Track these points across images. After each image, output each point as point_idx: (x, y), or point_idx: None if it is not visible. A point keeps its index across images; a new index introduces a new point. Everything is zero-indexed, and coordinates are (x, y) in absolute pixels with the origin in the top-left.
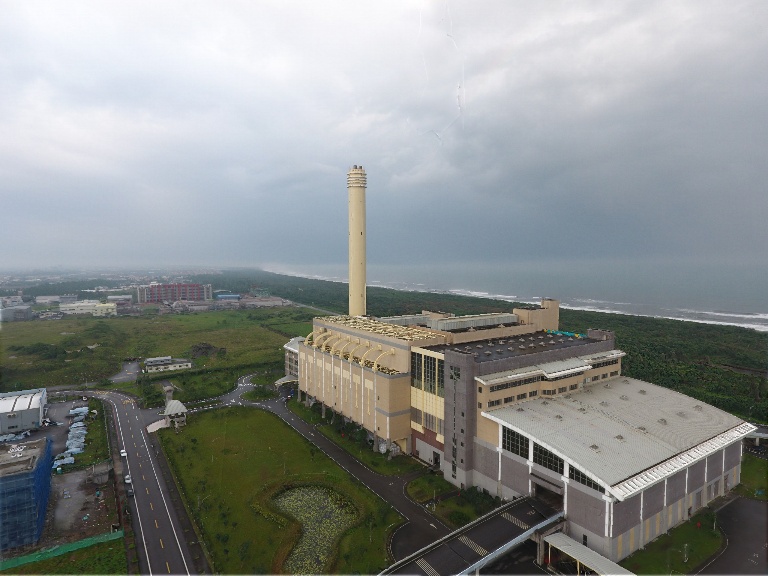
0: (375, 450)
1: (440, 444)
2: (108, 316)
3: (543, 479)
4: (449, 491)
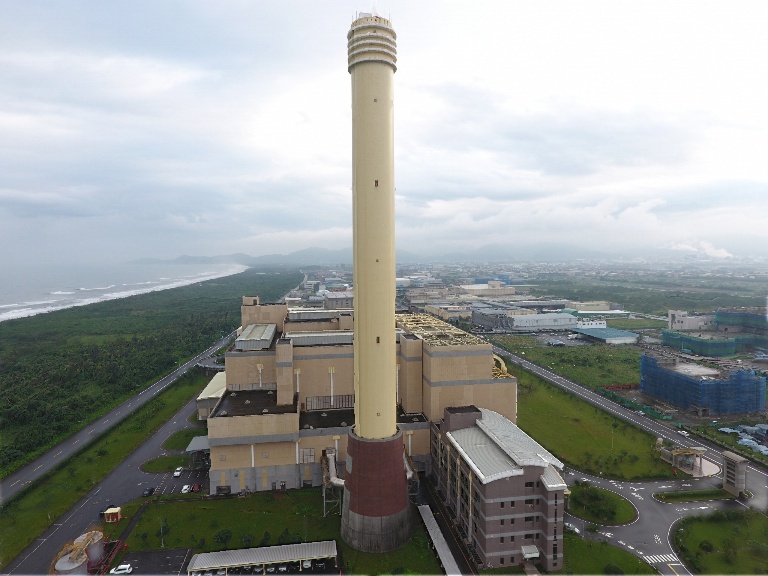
0: None
1: None
2: None
3: None
4: None
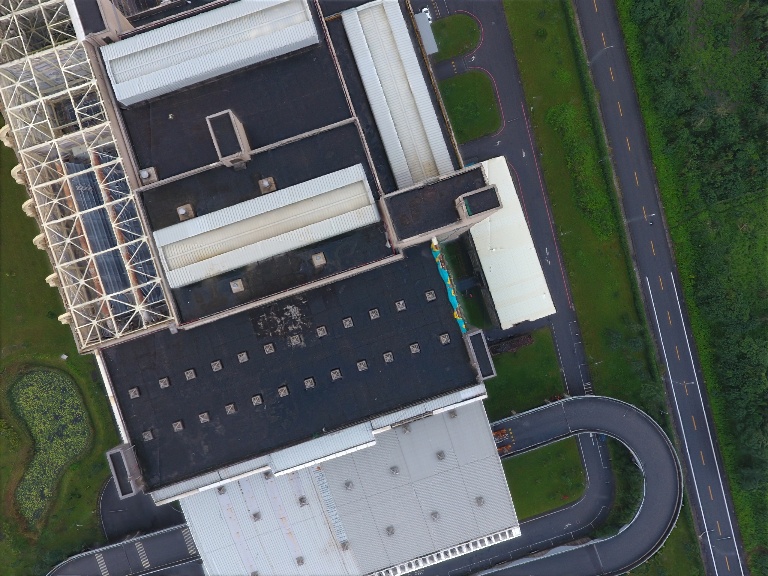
0: None
1: None
2: None
3: None
4: None
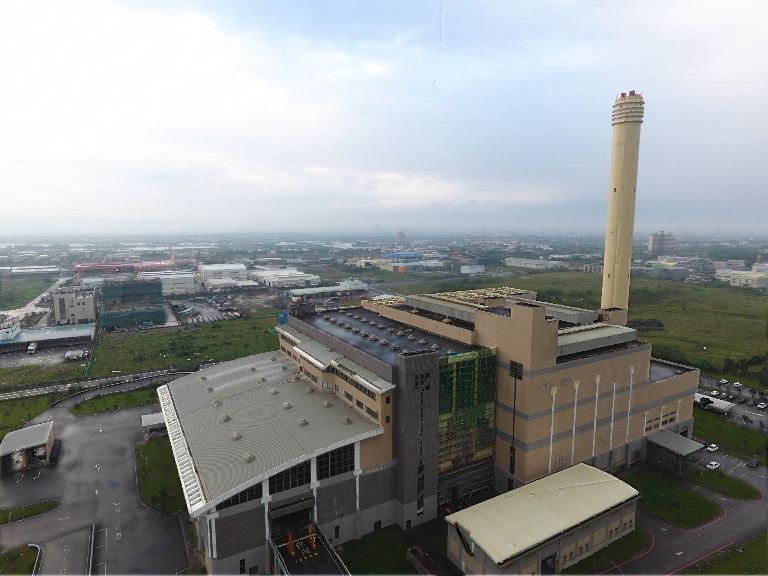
0: None
1: None
2: (744, 287)
3: None
4: None
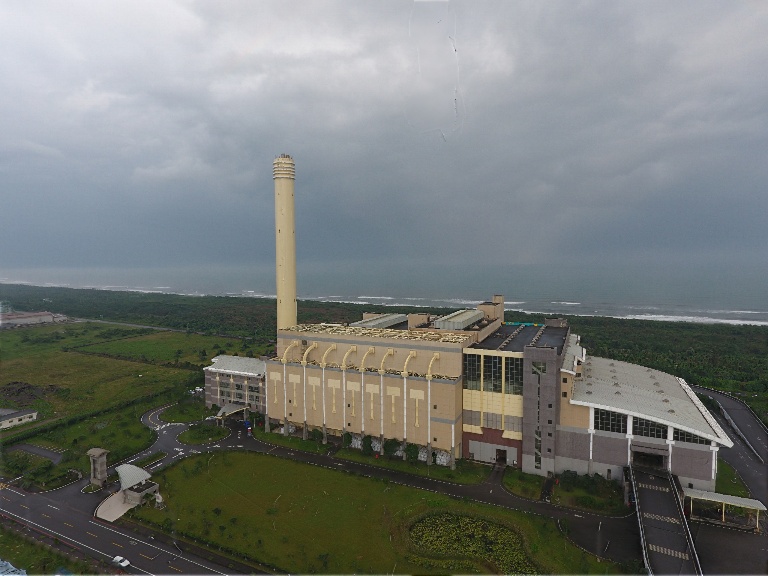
0: (430, 463)
1: (508, 440)
2: None
3: (646, 447)
4: (543, 482)
